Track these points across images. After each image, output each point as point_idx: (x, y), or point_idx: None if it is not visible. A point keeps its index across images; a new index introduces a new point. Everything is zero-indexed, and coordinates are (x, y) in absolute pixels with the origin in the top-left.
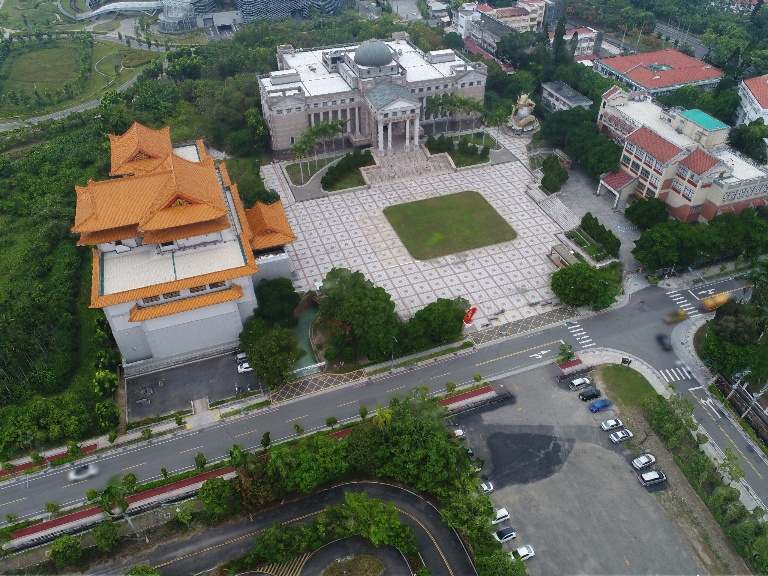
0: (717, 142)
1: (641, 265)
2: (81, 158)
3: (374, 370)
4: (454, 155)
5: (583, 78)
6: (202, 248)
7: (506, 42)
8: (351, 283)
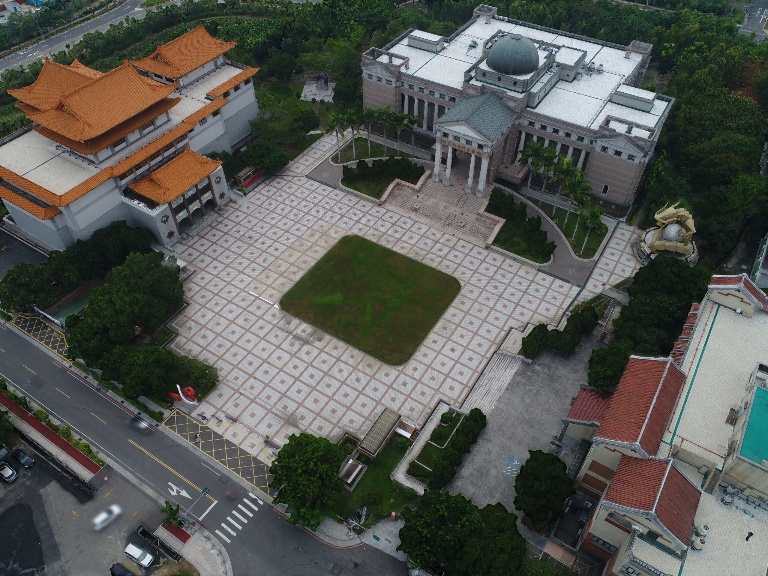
0: (760, 487)
1: None
2: (242, 44)
3: (83, 363)
4: (514, 229)
5: None
6: (79, 161)
7: None
8: (139, 274)
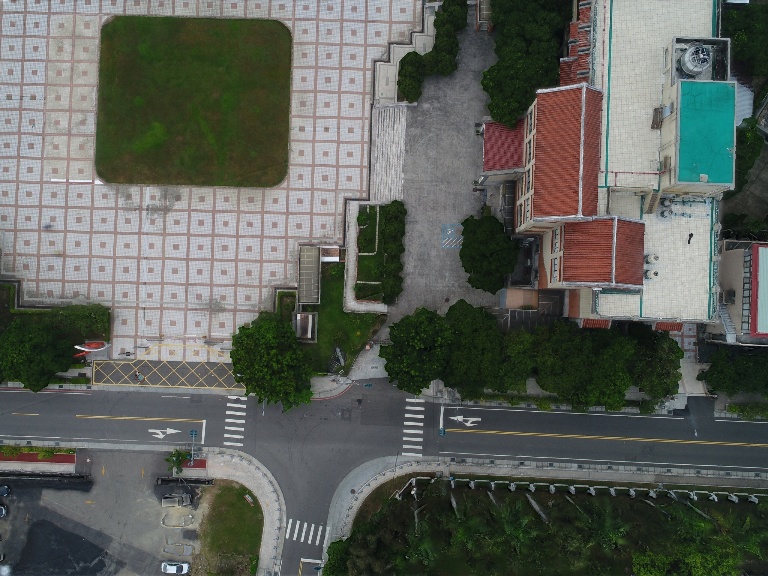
0: (696, 190)
1: None
2: None
3: None
4: None
5: None
6: None
7: None
8: None
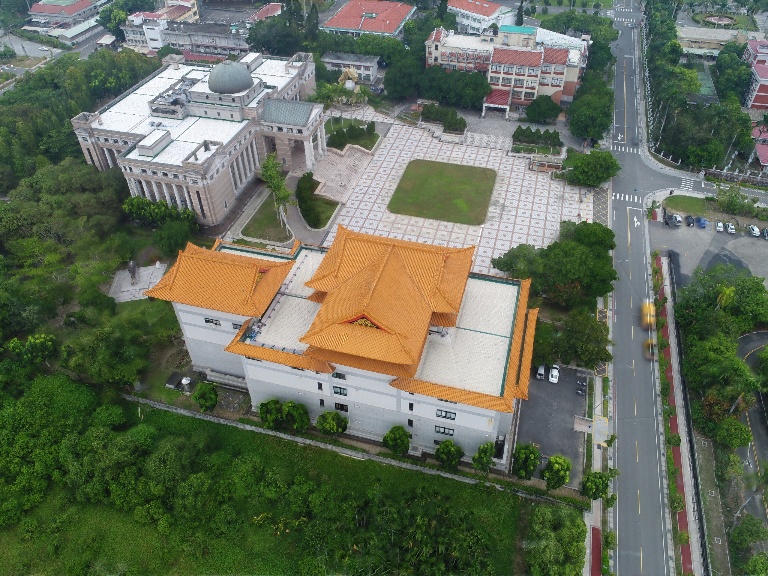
0: None
1: (578, 142)
2: None
3: (603, 303)
4: (352, 143)
5: (339, 43)
6: None
7: (266, 32)
8: None
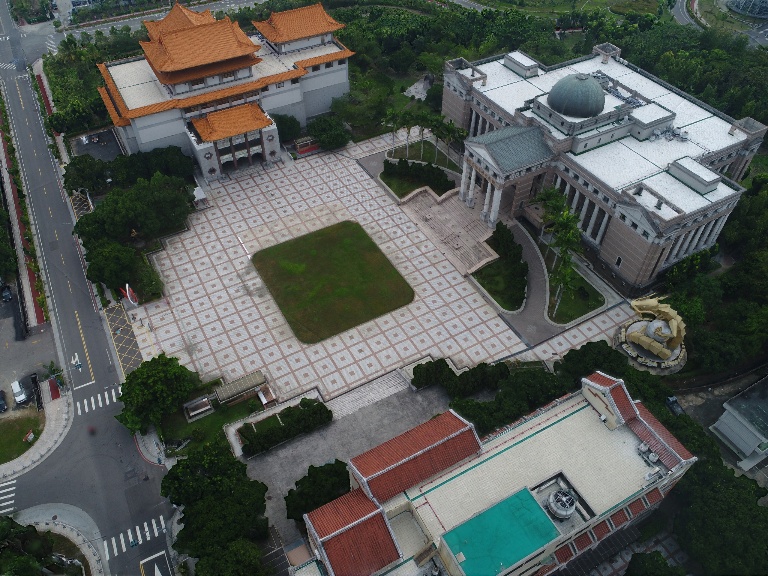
0: None
1: None
2: None
3: None
4: (502, 268)
5: None
6: (164, 89)
7: None
8: None
